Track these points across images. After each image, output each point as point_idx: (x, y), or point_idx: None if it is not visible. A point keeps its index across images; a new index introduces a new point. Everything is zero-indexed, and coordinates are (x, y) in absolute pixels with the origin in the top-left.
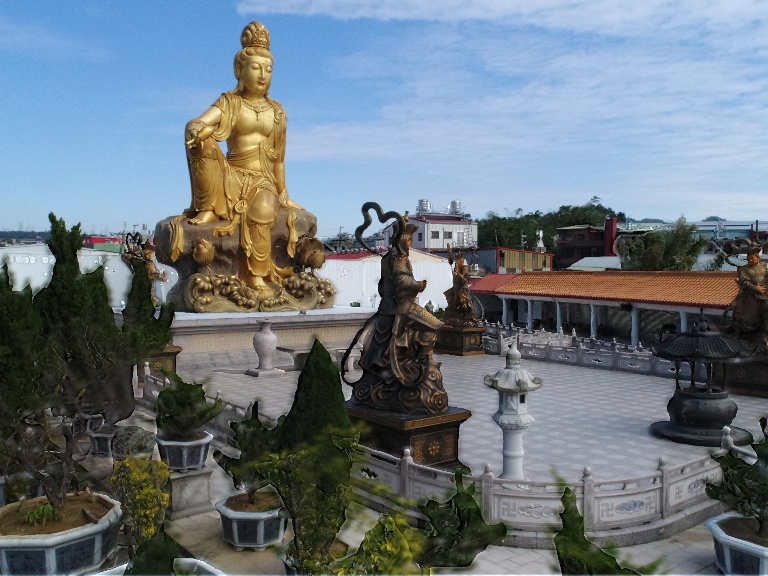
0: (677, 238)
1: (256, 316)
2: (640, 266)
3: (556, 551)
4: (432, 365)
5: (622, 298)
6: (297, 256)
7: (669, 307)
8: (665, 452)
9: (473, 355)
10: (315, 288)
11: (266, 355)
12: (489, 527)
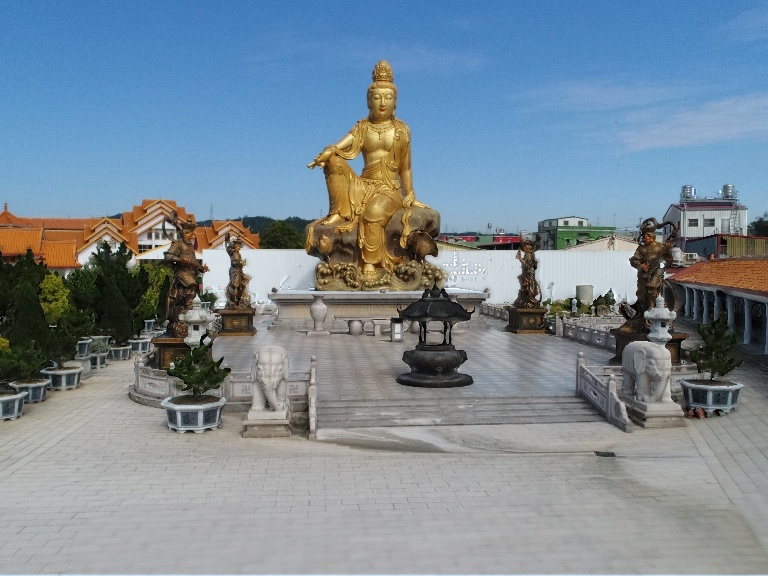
0: None
1: (341, 293)
2: None
3: (150, 407)
4: (188, 309)
5: (712, 284)
6: (411, 247)
7: (732, 292)
8: (365, 384)
9: (529, 333)
10: (418, 273)
11: (317, 320)
12: (5, 360)
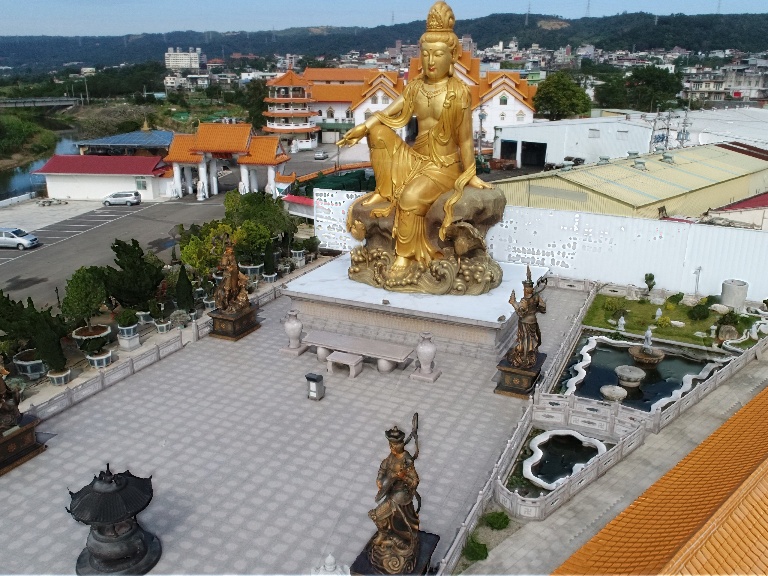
0: None
1: (344, 298)
2: None
3: None
4: None
5: None
6: None
7: None
8: (58, 543)
9: (509, 396)
10: (449, 275)
11: None
12: None
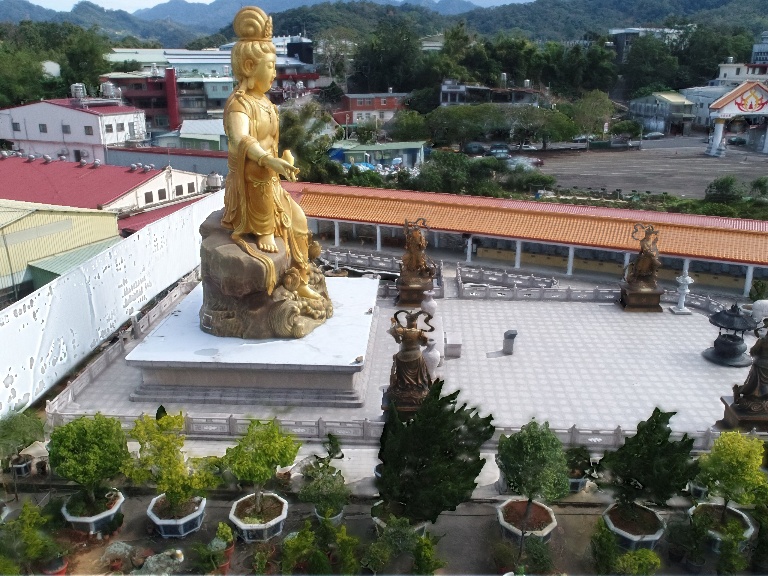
0: (306, 115)
1: (368, 330)
2: (286, 144)
3: None
4: None
5: (468, 231)
6: None
7: None
8: None
9: None
10: None
11: None
12: None
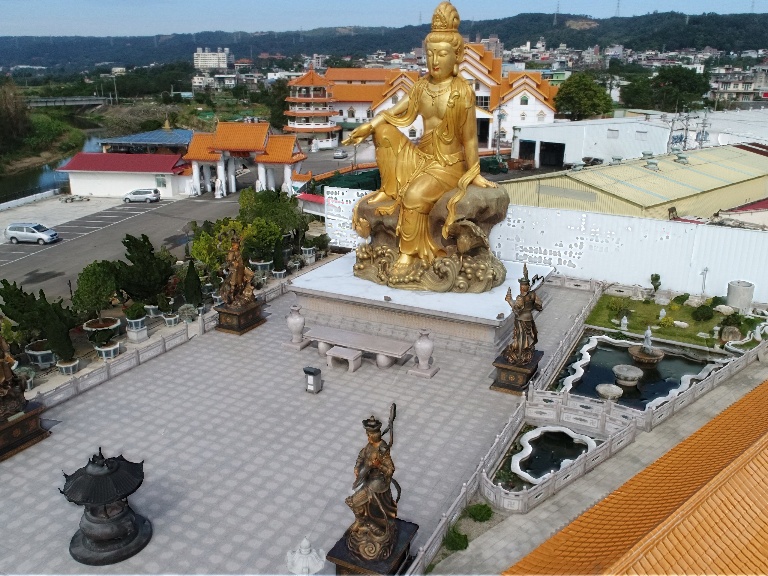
0: None
1: (347, 294)
2: None
3: None
4: None
5: None
6: None
7: None
8: (55, 524)
9: (504, 393)
10: (451, 273)
11: None
12: None
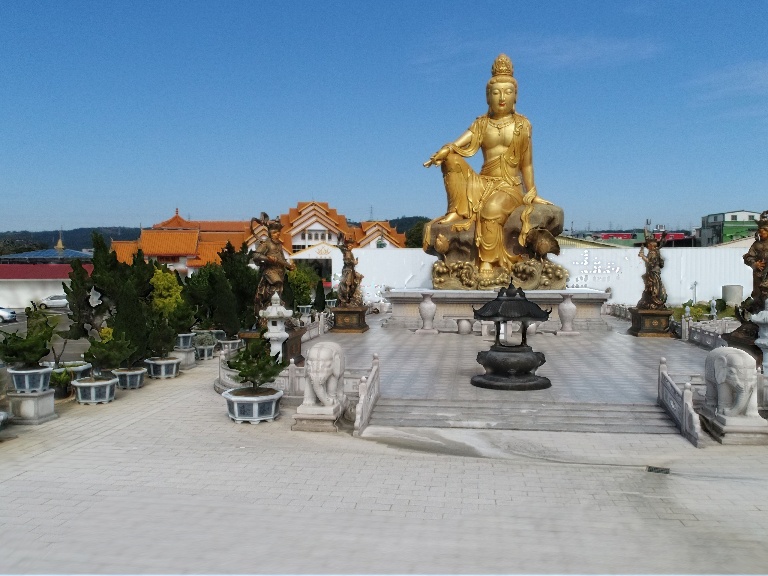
0: None
1: (454, 292)
2: None
3: None
4: None
5: None
6: (531, 245)
7: None
8: (436, 384)
9: (652, 337)
10: (537, 272)
11: (425, 319)
12: (97, 349)
